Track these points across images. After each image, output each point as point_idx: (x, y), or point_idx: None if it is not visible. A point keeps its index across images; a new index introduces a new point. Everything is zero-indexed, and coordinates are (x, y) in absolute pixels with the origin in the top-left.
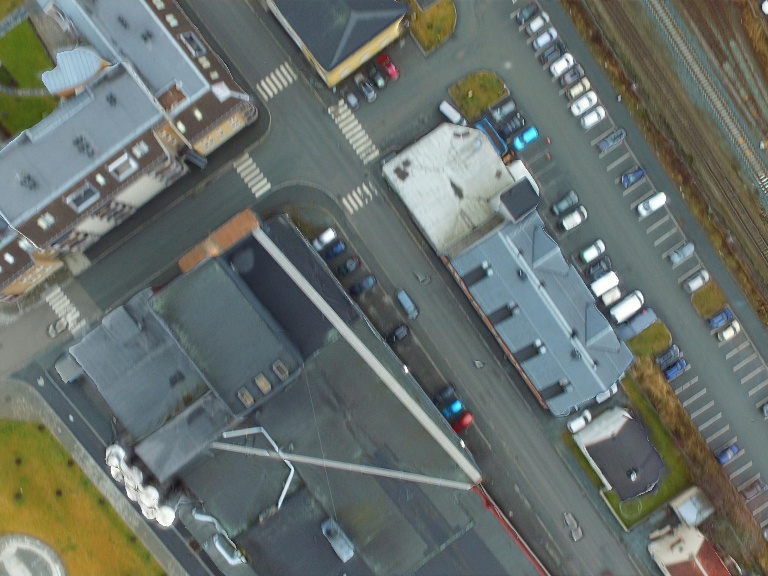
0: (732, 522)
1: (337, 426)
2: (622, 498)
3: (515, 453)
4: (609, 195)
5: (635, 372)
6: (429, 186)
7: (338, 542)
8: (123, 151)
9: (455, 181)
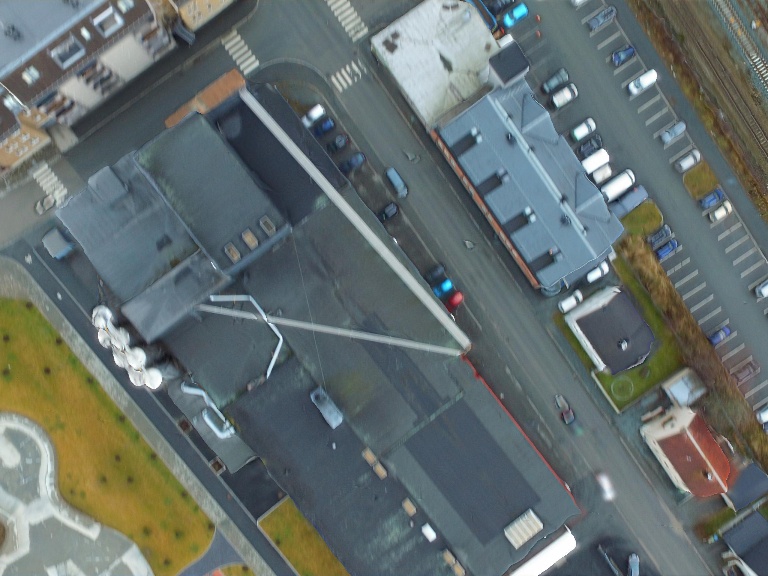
0: (724, 404)
1: (326, 294)
2: (613, 372)
3: (506, 335)
4: (600, 74)
5: (626, 252)
6: (418, 59)
7: (327, 408)
8: (108, 4)
9: (444, 54)
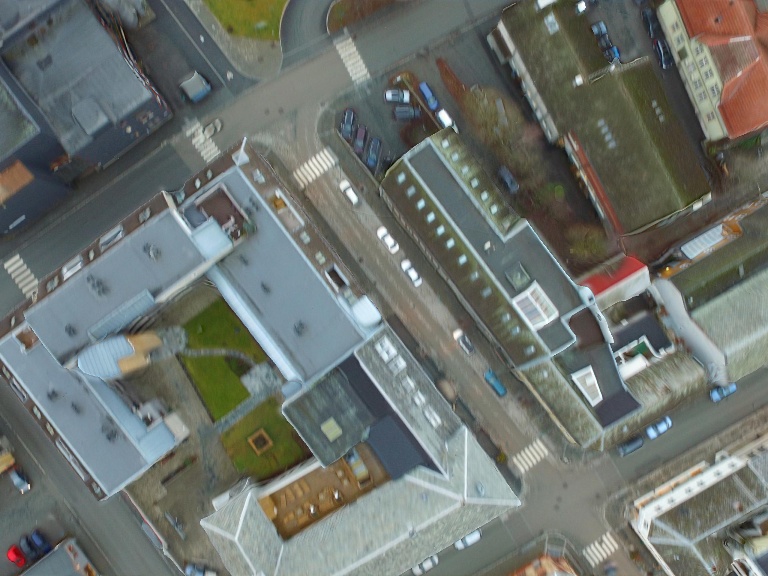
0: None
1: None
2: None
3: None
4: None
5: None
6: None
7: None
8: None
9: None
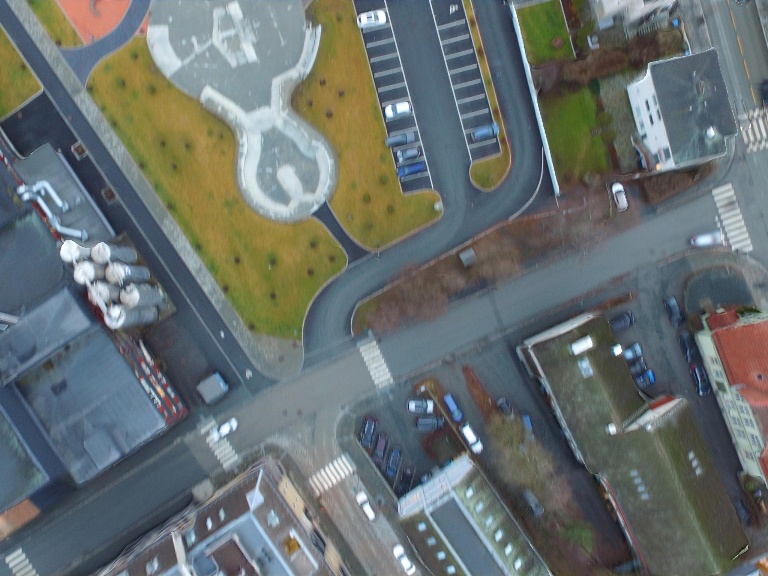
0: None
1: None
2: None
3: None
4: None
5: None
6: None
7: None
8: None
9: None
